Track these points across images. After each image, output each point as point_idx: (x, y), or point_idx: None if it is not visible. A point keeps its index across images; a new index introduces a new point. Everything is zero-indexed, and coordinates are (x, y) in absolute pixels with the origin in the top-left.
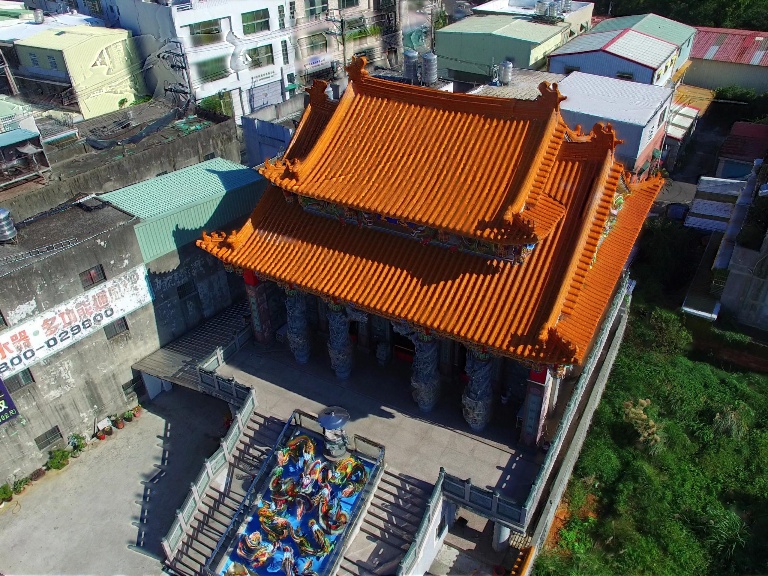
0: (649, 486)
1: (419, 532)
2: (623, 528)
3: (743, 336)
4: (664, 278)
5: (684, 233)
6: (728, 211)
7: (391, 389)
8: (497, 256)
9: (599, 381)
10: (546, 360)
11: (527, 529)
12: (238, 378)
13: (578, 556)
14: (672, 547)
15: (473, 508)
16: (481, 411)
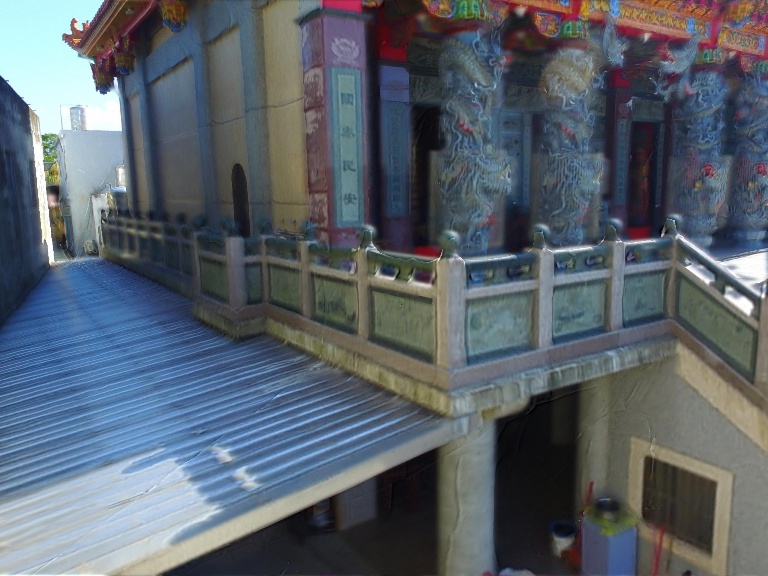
0: None
1: None
2: None
3: None
4: None
5: None
6: None
7: None
8: None
9: None
10: None
11: None
12: None
13: None
14: None
15: None
16: None
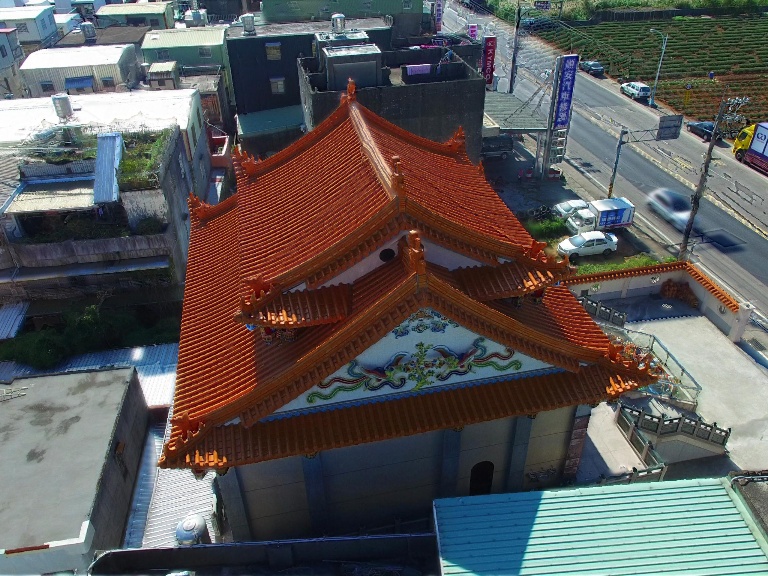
0: None
1: None
2: None
3: None
4: (143, 326)
5: None
6: None
7: None
8: None
9: None
10: None
11: None
12: (618, 461)
13: None
14: None
15: None
16: None
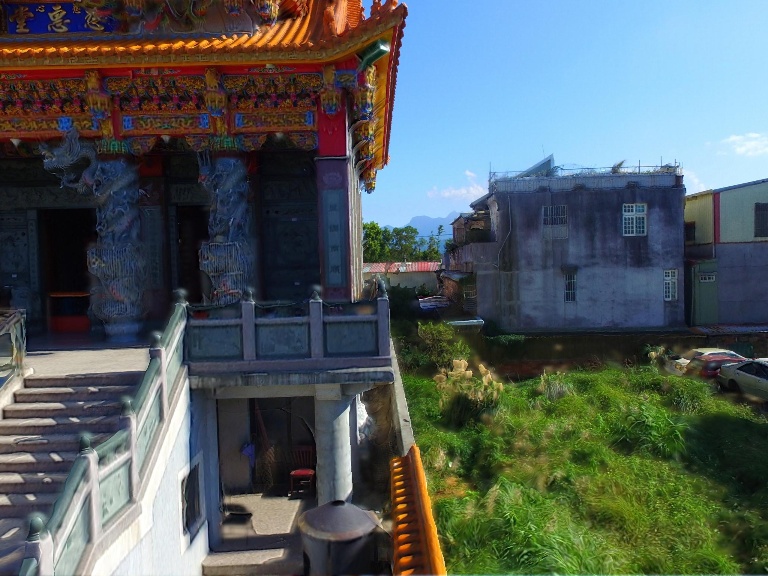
0: (523, 427)
1: (136, 408)
2: (526, 470)
3: (516, 335)
4: None
5: (413, 290)
6: (438, 303)
7: (42, 341)
8: (225, 31)
9: (393, 359)
10: (347, 35)
11: (377, 506)
12: None
13: (492, 490)
14: (609, 461)
15: (267, 372)
16: (240, 269)
